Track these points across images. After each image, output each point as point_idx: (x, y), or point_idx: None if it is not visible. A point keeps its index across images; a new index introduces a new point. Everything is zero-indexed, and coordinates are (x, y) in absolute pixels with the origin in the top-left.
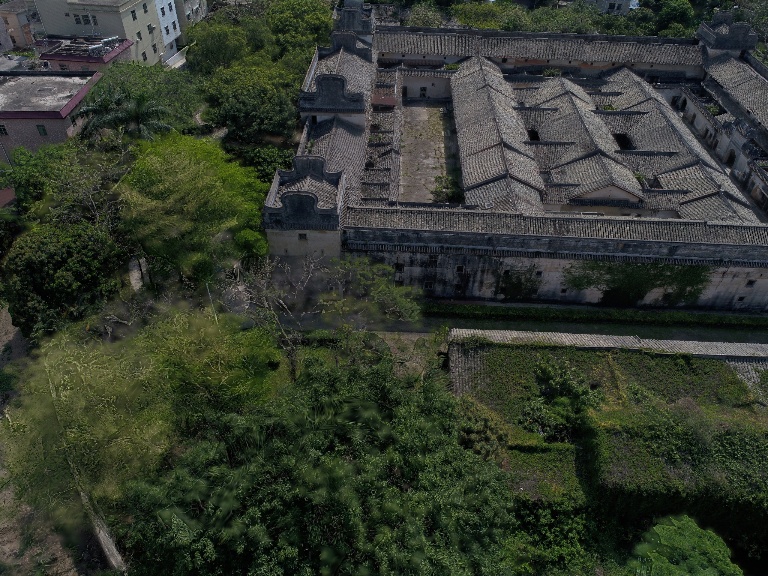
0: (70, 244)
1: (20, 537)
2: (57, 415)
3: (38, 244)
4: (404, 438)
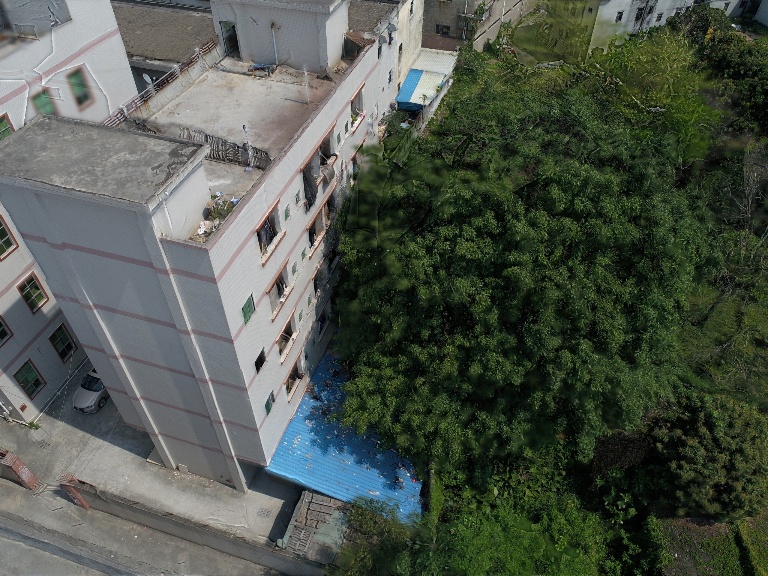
0: (765, 68)
1: (507, 185)
2: (598, 150)
3: (745, 49)
4: (570, 178)
